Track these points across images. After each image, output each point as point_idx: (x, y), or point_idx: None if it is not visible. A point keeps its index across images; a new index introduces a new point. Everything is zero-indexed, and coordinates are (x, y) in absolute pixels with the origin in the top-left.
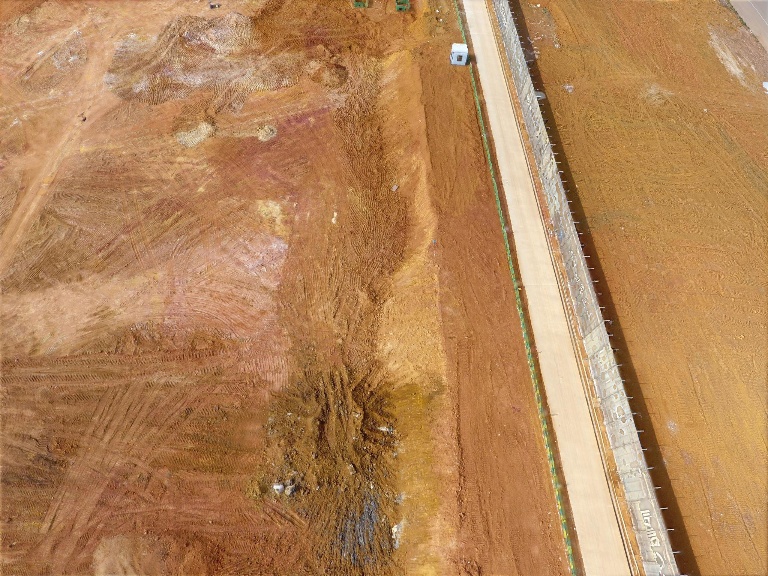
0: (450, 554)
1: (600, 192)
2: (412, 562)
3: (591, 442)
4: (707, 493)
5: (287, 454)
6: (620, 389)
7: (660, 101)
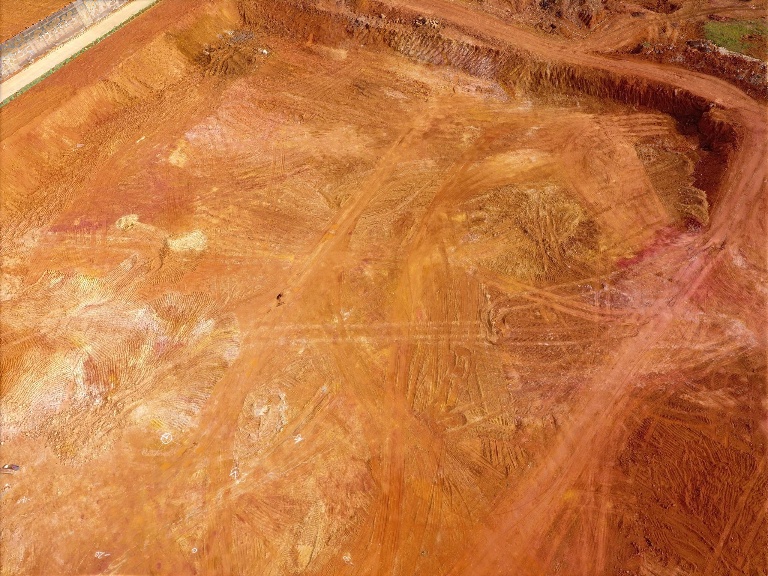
0: (213, 5)
1: None
2: None
3: (130, 6)
4: None
5: None
6: None
7: None
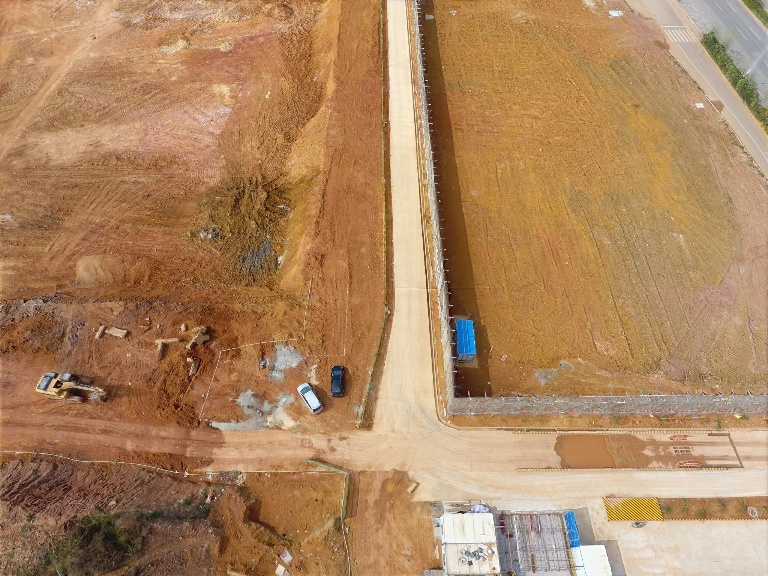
0: (306, 252)
1: (459, 71)
2: (287, 271)
3: (415, 200)
4: (488, 225)
5: (211, 215)
6: (431, 158)
7: (523, 21)
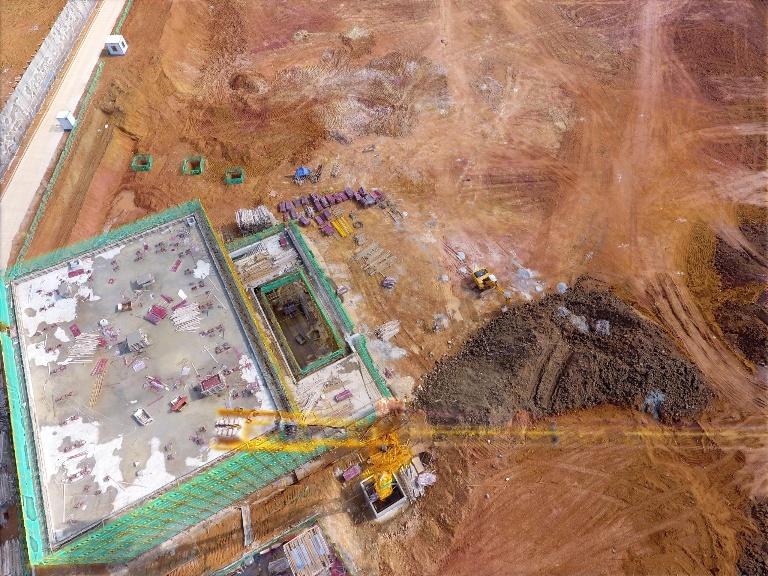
0: None
1: None
2: None
3: None
4: None
5: None
6: None
7: None
